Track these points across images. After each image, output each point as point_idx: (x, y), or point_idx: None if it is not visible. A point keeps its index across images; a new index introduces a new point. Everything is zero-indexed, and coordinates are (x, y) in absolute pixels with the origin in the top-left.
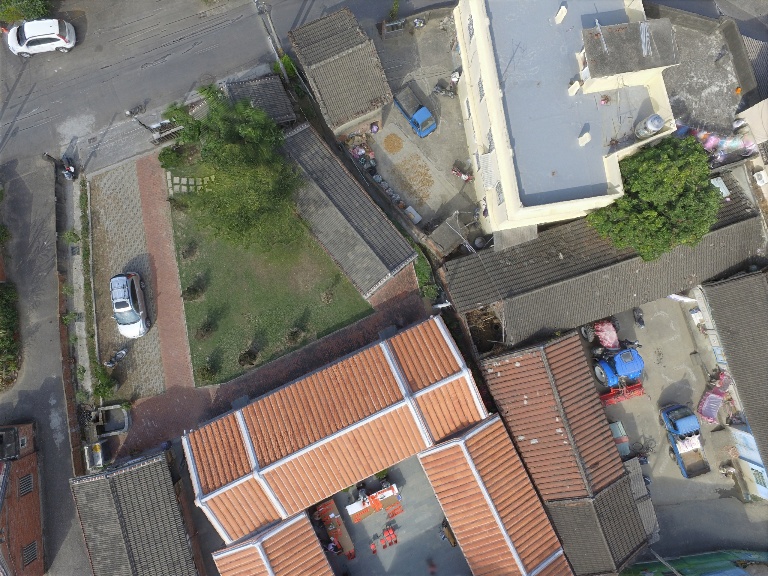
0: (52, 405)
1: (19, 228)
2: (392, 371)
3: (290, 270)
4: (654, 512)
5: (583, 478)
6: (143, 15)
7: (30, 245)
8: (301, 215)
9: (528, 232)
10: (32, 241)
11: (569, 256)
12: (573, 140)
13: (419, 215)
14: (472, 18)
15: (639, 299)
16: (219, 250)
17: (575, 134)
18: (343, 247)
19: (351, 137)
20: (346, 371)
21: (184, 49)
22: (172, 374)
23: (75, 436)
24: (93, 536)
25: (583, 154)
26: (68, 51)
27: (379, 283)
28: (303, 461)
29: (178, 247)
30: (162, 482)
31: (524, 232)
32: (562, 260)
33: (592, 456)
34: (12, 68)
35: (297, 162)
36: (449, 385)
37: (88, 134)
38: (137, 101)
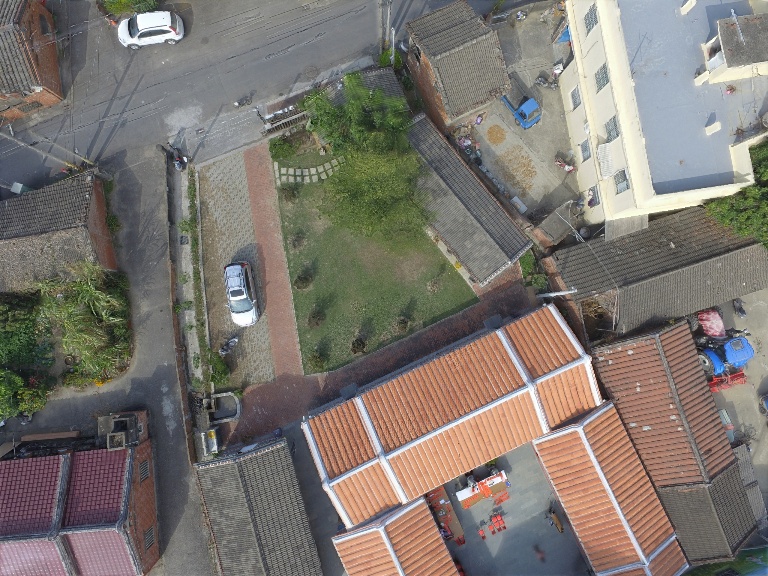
0: (164, 392)
1: (129, 218)
2: (511, 358)
3: (396, 260)
4: (762, 498)
5: (699, 464)
6: (248, 8)
7: (140, 235)
8: (418, 204)
9: (639, 221)
10: (142, 231)
11: (680, 245)
12: (700, 129)
13: (525, 205)
14: (599, 9)
15: (748, 288)
16: (326, 240)
17: (702, 123)
18: (461, 236)
19: (457, 128)
20: (464, 358)
21: (289, 41)
22: (281, 362)
23: (188, 423)
24: (218, 520)
25: (710, 143)
26: (175, 43)
27: (498, 271)
28: (426, 446)
29: (286, 237)
30: (285, 467)
31: (635, 221)
32: (674, 249)
33: (705, 442)
34: (120, 60)
35: (417, 152)
36: (569, 372)
37: (195, 125)
38: (243, 93)
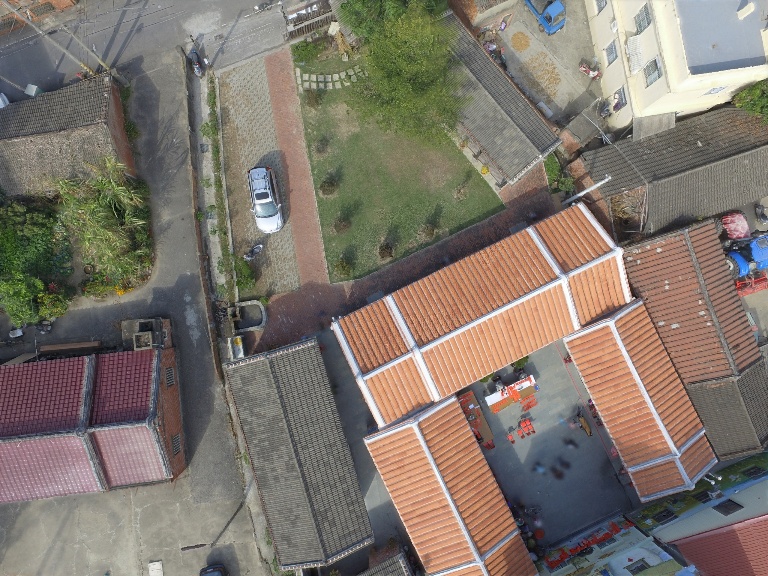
0: (187, 302)
1: (147, 125)
2: (542, 253)
3: (421, 167)
4: None
5: (728, 357)
6: None
7: (159, 142)
8: None
9: (666, 121)
10: (161, 138)
11: (707, 144)
12: (732, 14)
13: (550, 110)
14: None
15: None
16: (350, 147)
17: (733, 8)
18: (490, 132)
19: (482, 32)
20: (495, 255)
21: None
22: (306, 270)
23: (212, 331)
24: (249, 419)
25: (742, 28)
26: None
27: (528, 166)
28: (459, 341)
29: (309, 144)
30: (316, 366)
31: (662, 121)
32: (701, 147)
33: (733, 338)
34: None
35: None
36: (600, 265)
37: (214, 31)
38: None
